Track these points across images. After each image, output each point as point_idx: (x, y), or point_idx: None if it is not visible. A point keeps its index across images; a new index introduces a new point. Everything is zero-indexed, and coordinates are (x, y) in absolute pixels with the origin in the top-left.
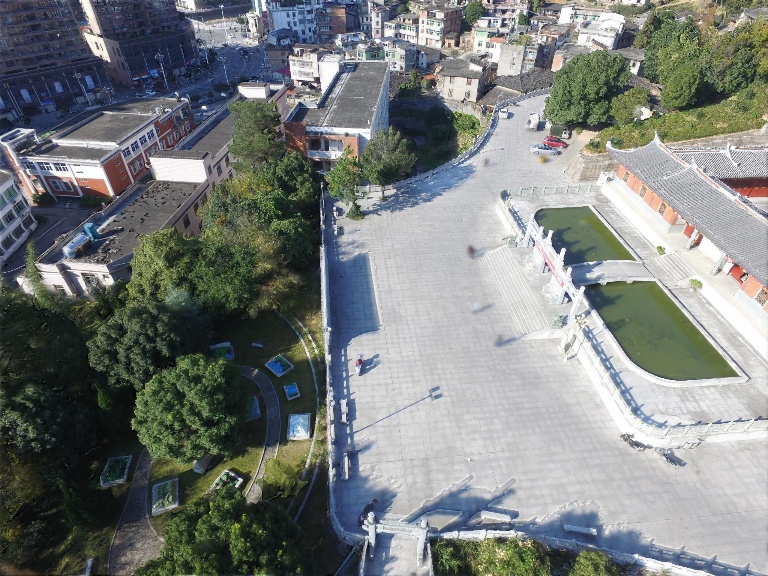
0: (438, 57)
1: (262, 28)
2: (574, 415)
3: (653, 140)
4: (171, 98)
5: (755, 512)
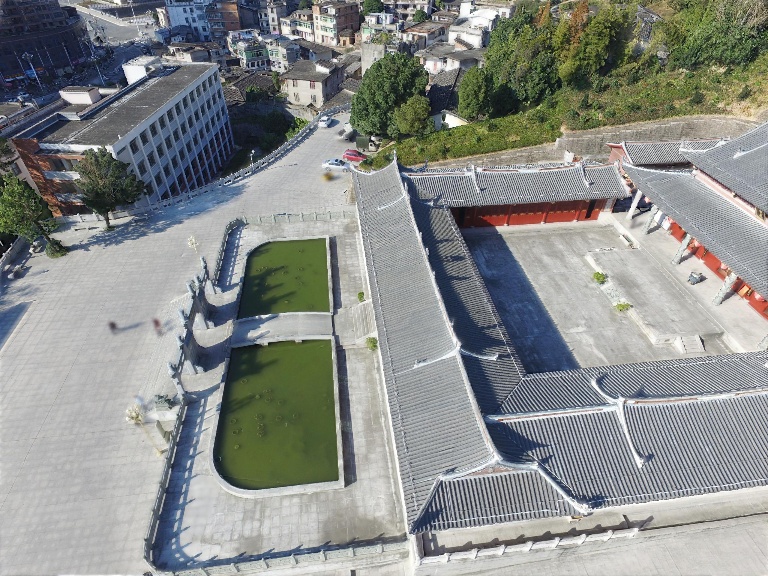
0: (330, 56)
1: (168, 24)
2: (110, 540)
3: (393, 161)
4: (16, 103)
5: None
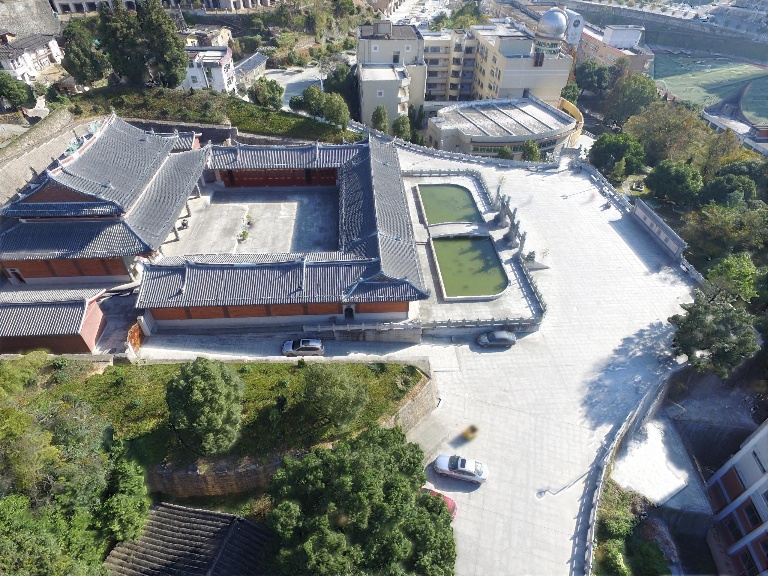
0: None
1: None
2: None
3: None
4: None
5: (439, 168)
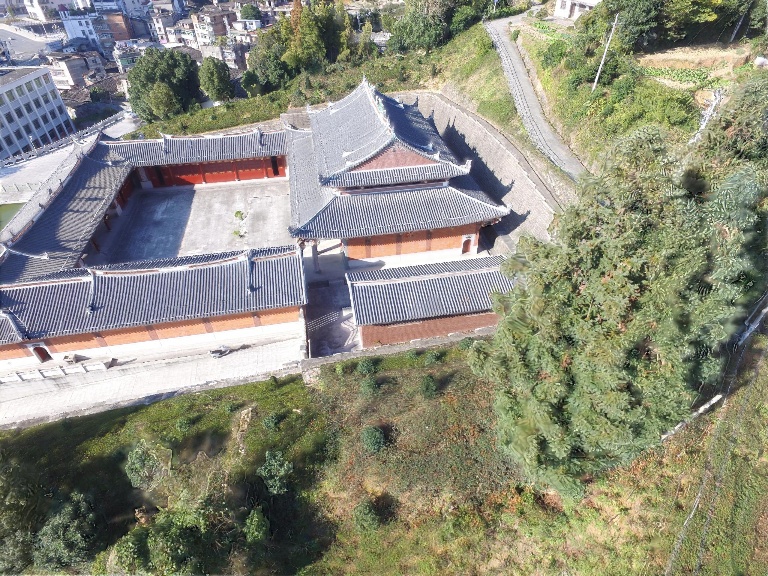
0: None
1: None
2: None
3: None
4: None
5: None
